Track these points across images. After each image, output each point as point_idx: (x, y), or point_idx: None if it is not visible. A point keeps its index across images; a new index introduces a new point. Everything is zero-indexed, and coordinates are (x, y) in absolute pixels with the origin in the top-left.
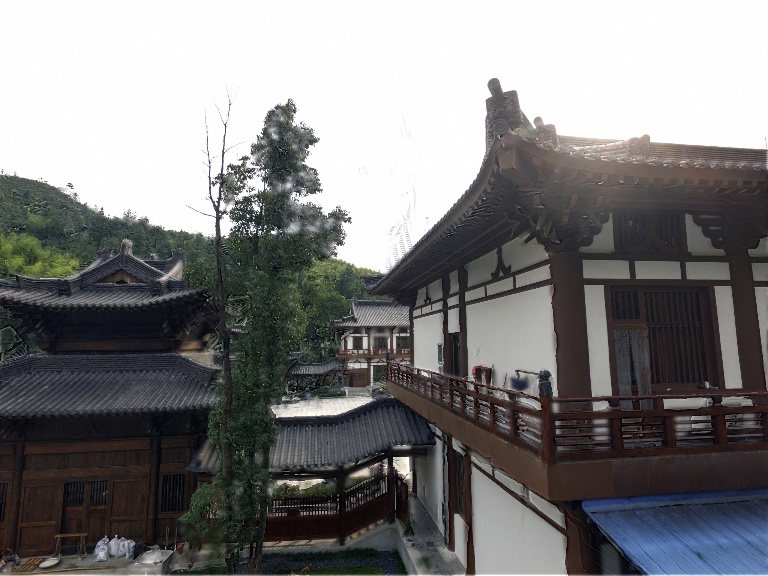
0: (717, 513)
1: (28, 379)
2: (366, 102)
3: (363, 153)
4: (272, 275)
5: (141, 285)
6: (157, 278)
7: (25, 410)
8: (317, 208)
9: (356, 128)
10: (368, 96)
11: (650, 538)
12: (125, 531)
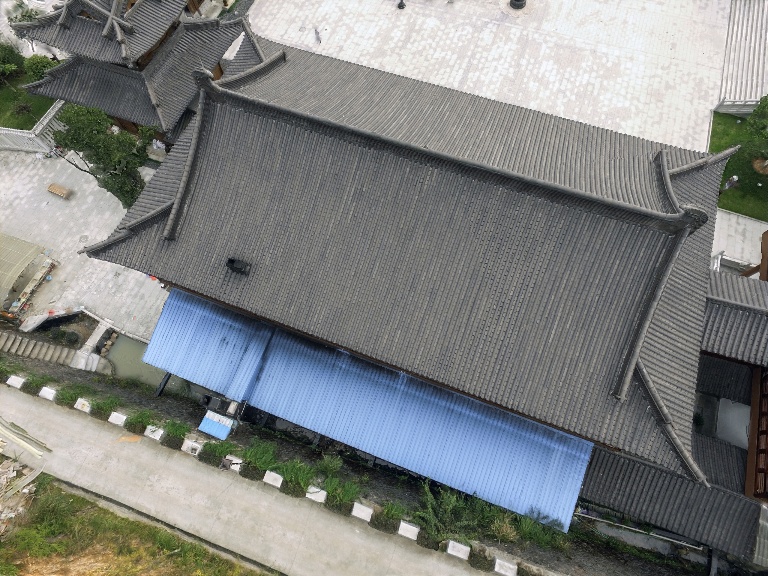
0: (198, 302)
1: (84, 69)
2: None
3: None
4: (105, 173)
5: (100, 22)
6: (106, 18)
7: (87, 104)
8: (110, 143)
9: None
10: None
11: (175, 300)
12: (161, 139)
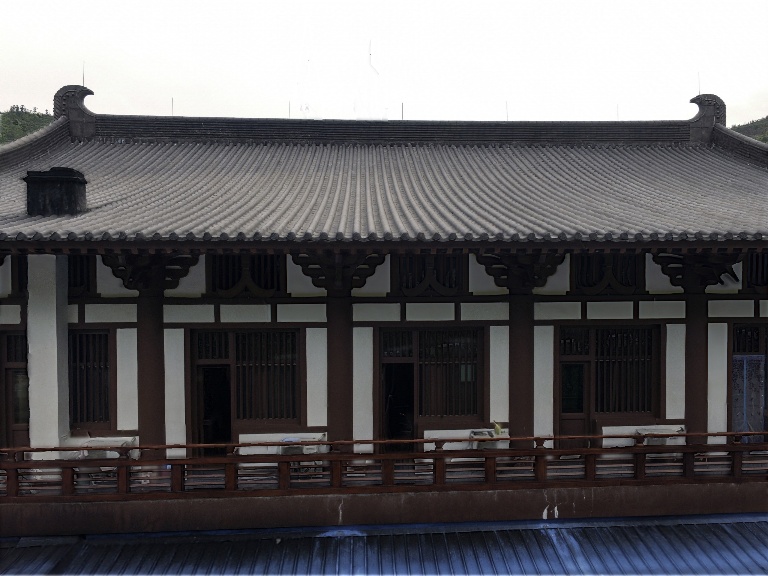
0: None
1: None
2: (308, 31)
3: (305, 89)
4: None
5: None
6: None
7: None
8: None
9: (298, 61)
10: (311, 24)
11: None
12: None
